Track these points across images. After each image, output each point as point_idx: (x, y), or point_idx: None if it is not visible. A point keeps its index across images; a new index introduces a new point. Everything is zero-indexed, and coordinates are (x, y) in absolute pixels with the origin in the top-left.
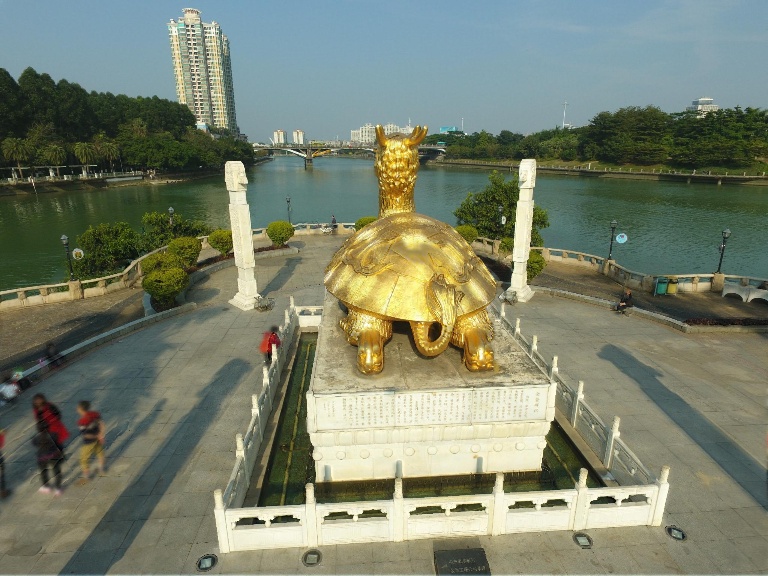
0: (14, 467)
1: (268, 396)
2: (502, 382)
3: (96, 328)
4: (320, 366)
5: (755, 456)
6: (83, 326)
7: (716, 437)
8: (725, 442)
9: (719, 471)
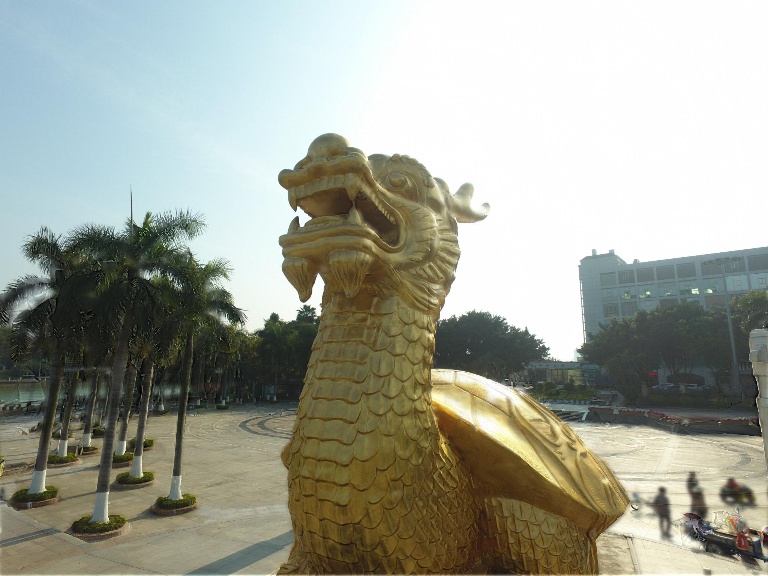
0: None
1: None
2: None
3: None
4: (626, 560)
5: (214, 560)
6: None
7: (202, 573)
8: (206, 570)
9: (260, 563)
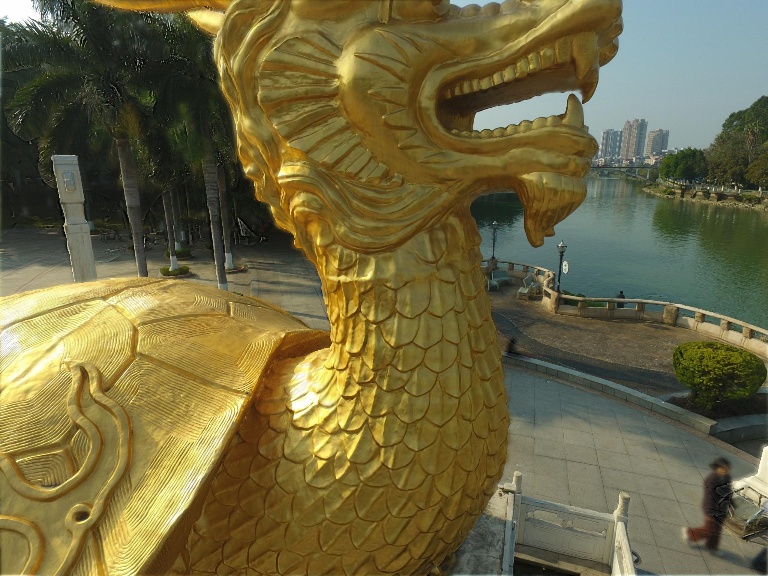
0: None
1: None
2: None
3: (669, 384)
4: None
5: None
6: (673, 376)
7: None
8: None
9: None
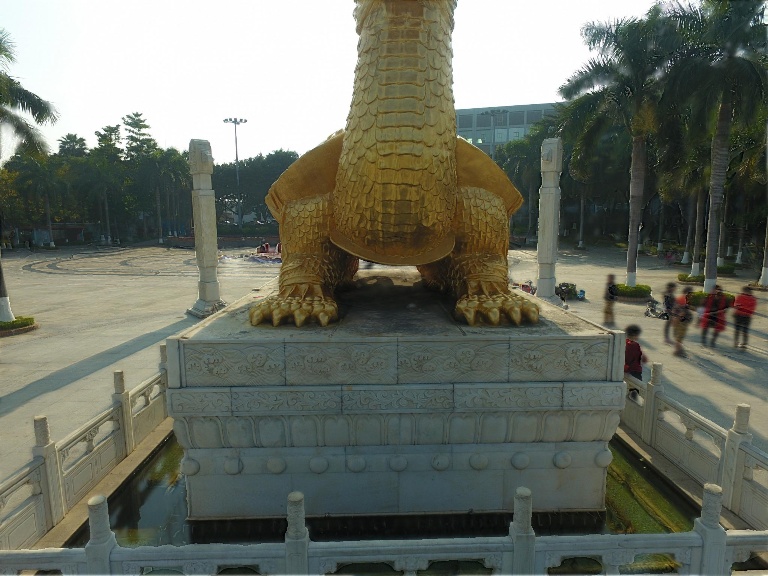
0: (737, 350)
1: None
2: None
3: None
4: None
5: None
6: None
7: None
8: (107, 353)
9: None
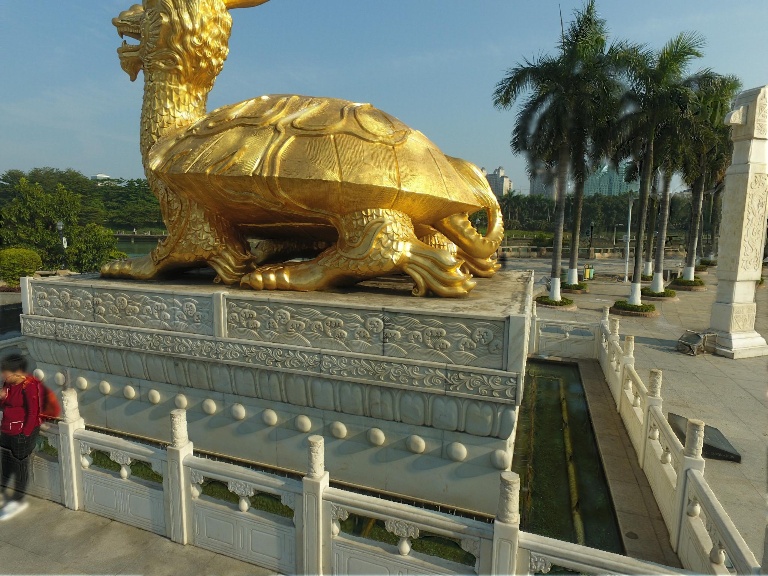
0: None
1: (200, 490)
2: (522, 276)
3: None
4: None
5: None
6: None
7: None
8: None
9: None
